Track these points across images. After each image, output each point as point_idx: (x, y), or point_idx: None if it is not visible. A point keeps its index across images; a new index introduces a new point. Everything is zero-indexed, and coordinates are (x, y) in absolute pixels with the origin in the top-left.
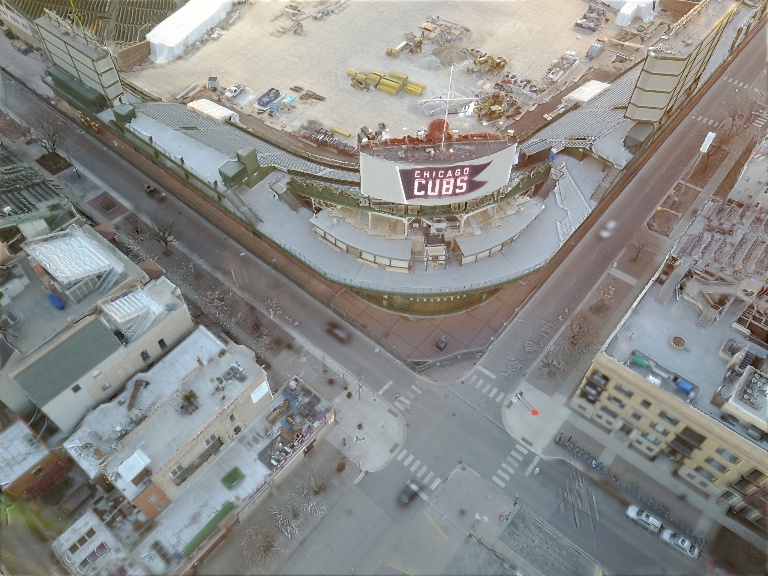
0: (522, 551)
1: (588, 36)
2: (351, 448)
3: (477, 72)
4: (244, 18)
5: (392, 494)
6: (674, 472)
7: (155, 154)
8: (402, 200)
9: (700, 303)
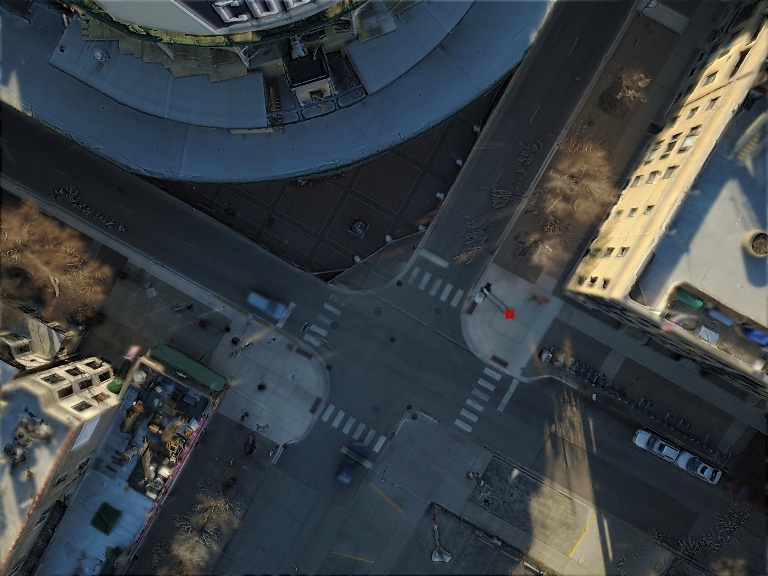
0: (498, 510)
1: None
2: (256, 418)
3: None
4: None
5: (324, 469)
6: (705, 372)
7: None
8: (206, 31)
9: None
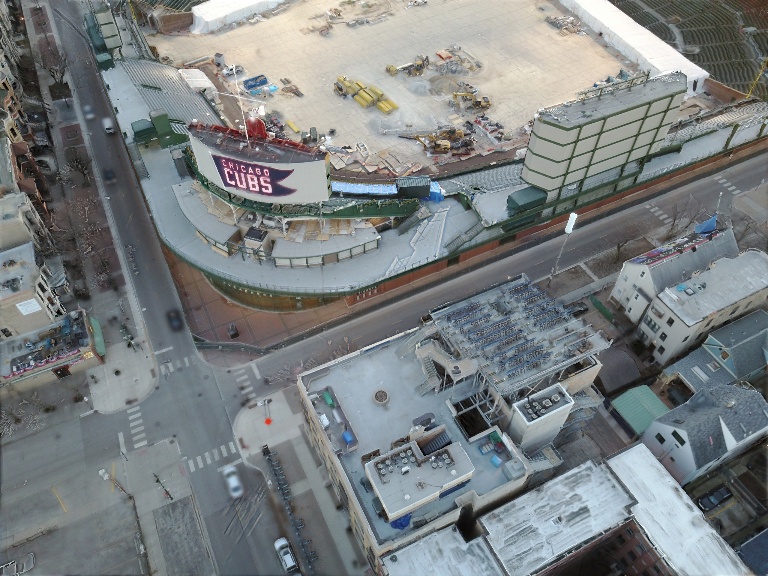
0: (162, 530)
1: None
2: (98, 387)
3: (456, 106)
4: (289, 11)
5: (101, 437)
6: (348, 527)
7: None
8: (222, 186)
9: (423, 367)
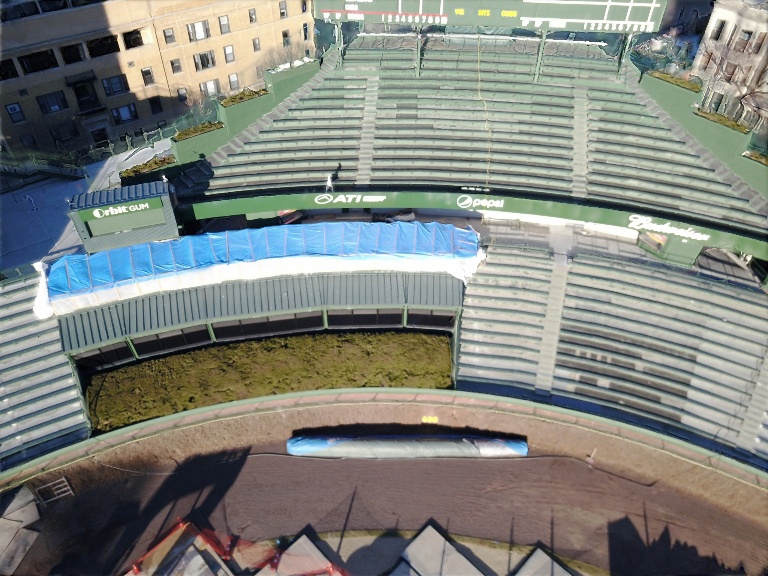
0: None
1: None
2: None
3: None
4: None
5: None
6: None
7: None
8: None
9: None
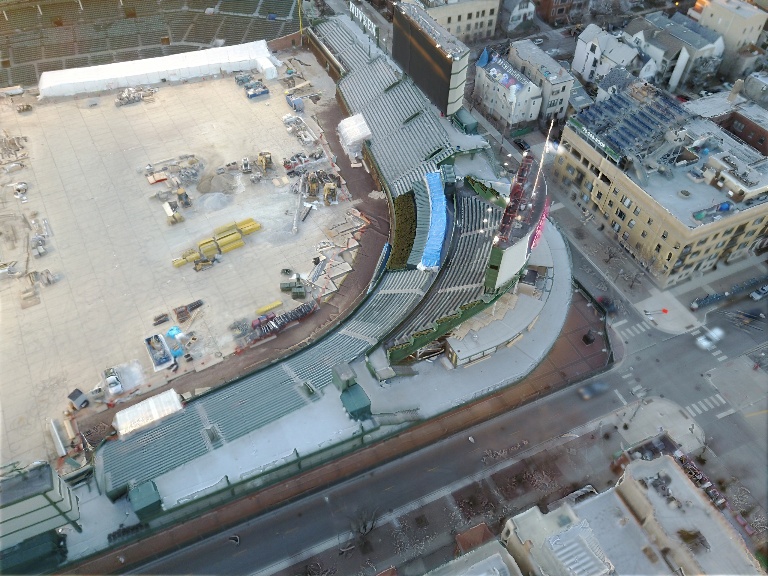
0: None
1: (270, 99)
2: None
3: (264, 177)
4: None
5: (729, 433)
6: (726, 263)
7: (231, 493)
8: (523, 263)
9: (663, 167)
